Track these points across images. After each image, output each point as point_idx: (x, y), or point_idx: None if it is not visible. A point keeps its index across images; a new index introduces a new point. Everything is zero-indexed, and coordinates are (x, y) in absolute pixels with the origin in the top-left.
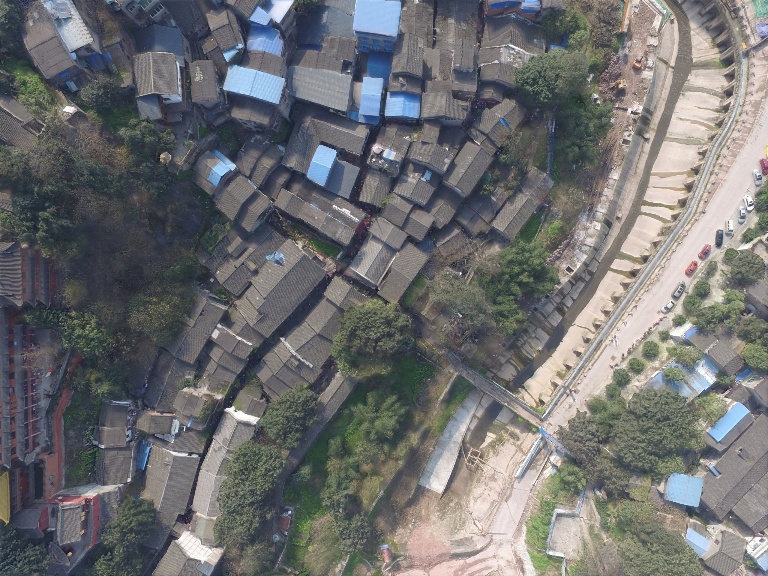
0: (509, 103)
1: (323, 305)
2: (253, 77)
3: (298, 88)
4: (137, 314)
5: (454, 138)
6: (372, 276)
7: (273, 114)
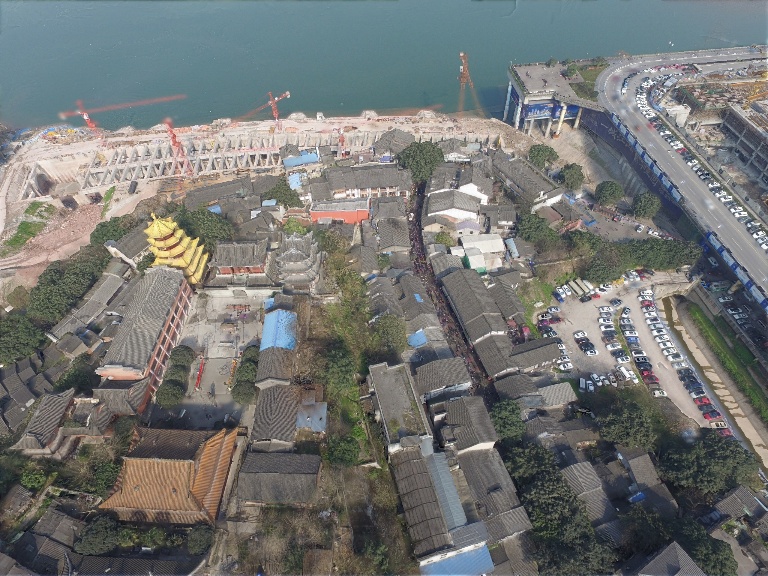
0: None
1: None
2: None
3: None
4: None
5: None
6: None
7: None
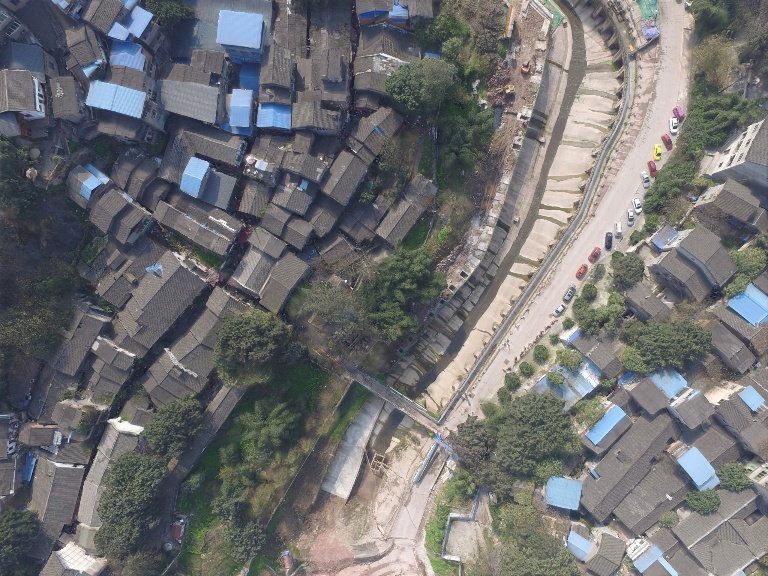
0: (384, 111)
1: (206, 315)
2: (114, 92)
3: (167, 101)
4: (5, 328)
5: (329, 147)
6: (253, 286)
7: (141, 128)
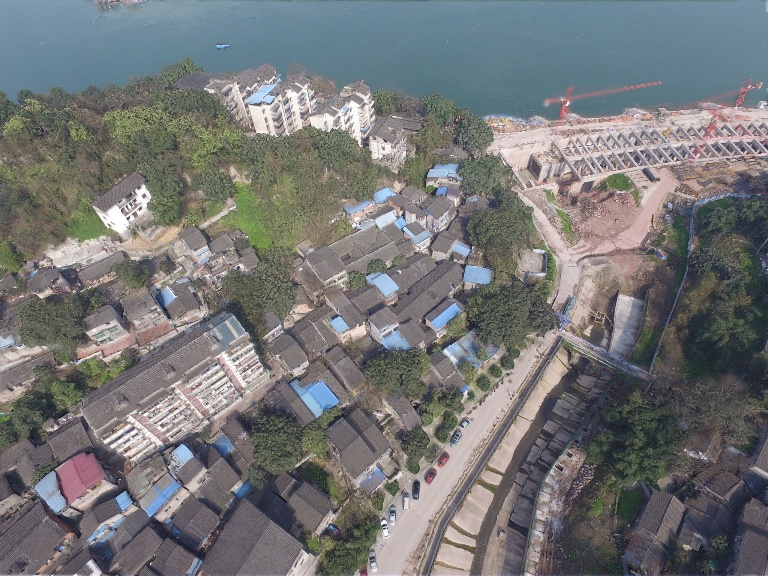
0: None
1: None
2: None
3: None
4: None
5: None
6: None
7: None
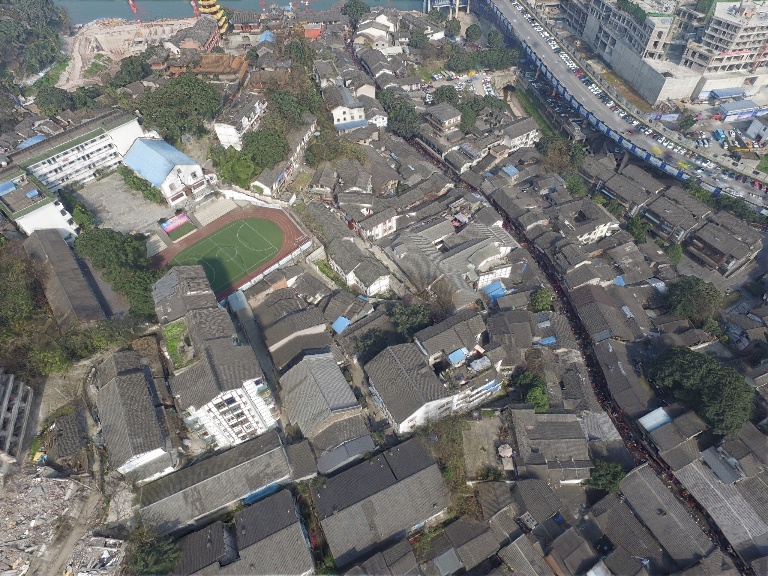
0: None
1: None
2: None
3: None
4: None
5: None
6: None
7: None
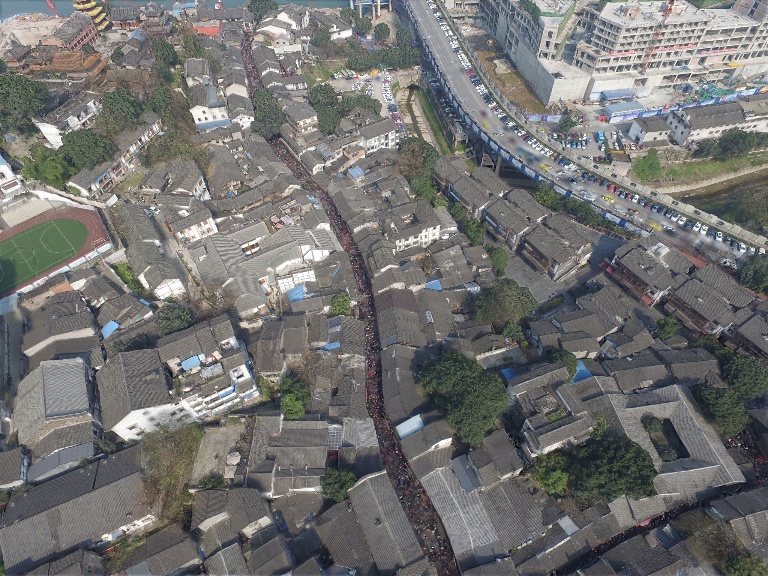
0: None
1: None
2: None
3: None
4: None
5: None
6: None
7: None
